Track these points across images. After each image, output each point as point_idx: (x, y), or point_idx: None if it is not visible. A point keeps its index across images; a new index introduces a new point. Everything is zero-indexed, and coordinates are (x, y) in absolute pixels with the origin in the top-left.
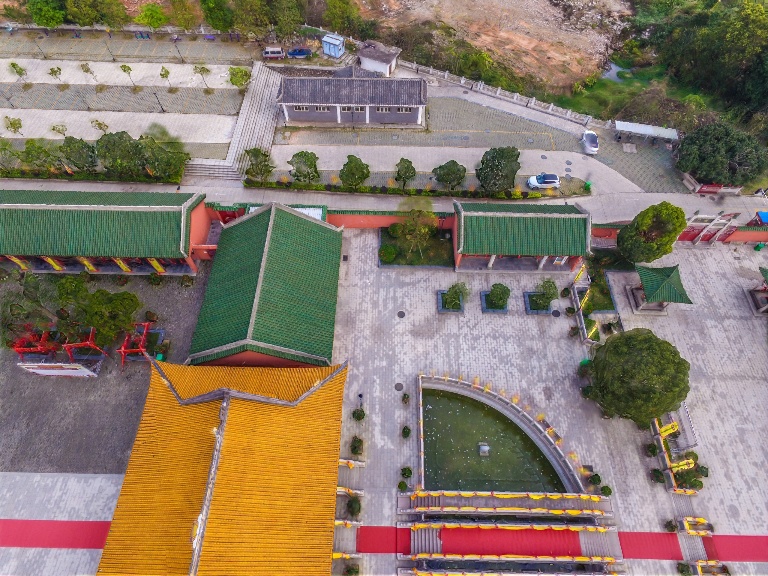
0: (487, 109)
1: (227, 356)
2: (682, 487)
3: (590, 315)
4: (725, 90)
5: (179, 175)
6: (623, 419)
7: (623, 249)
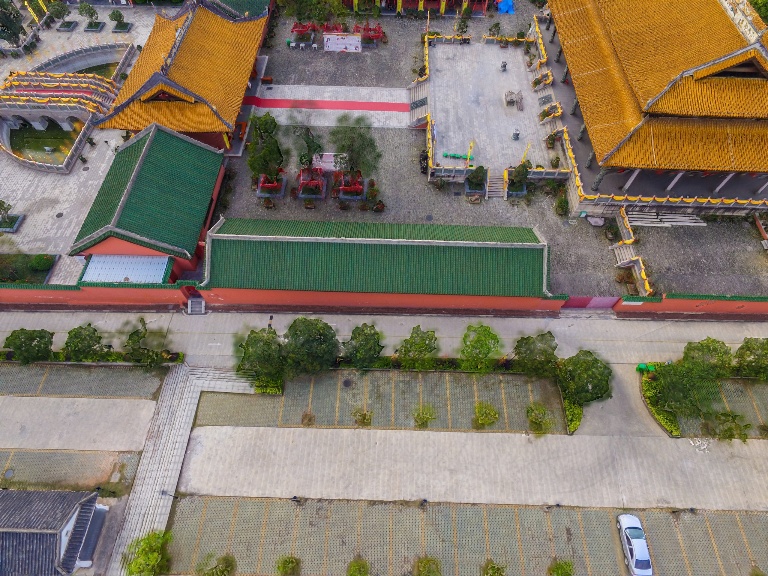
0: None
1: None
2: None
3: None
4: None
5: None
6: None
7: None
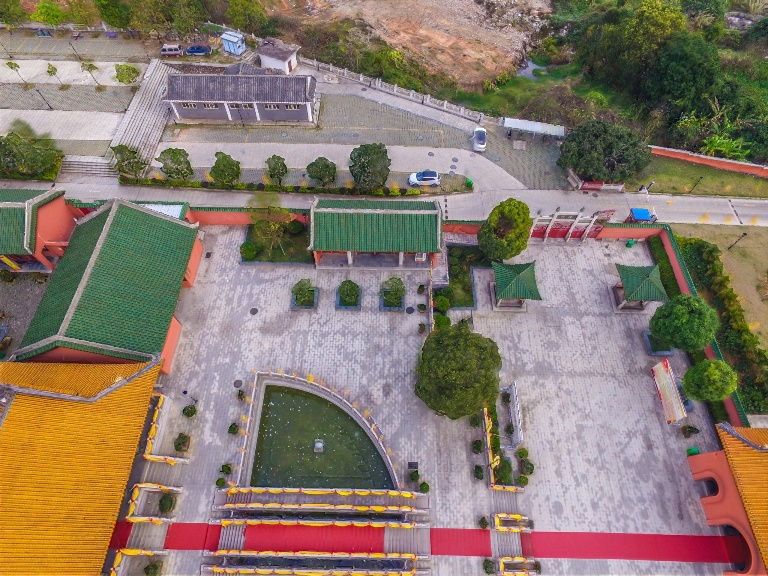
0: (382, 106)
1: (44, 352)
2: (501, 483)
3: (449, 312)
4: (632, 87)
5: (54, 172)
6: None
7: (481, 246)
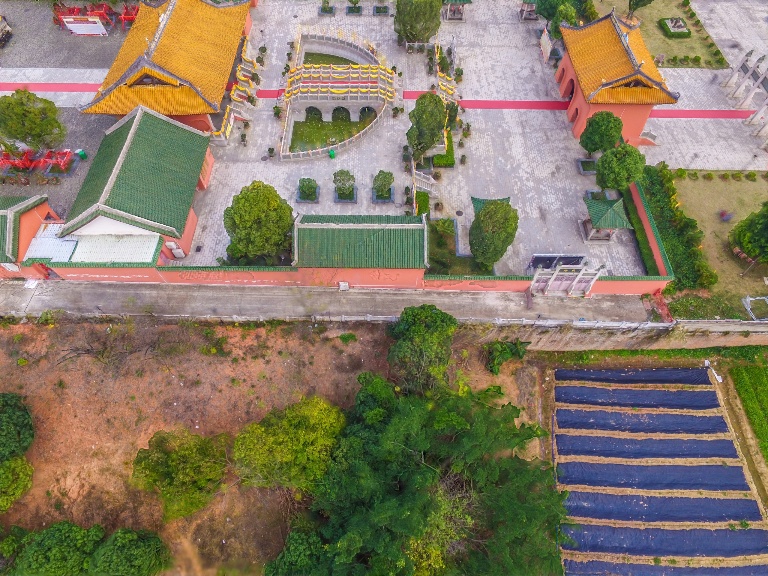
0: None
1: None
2: (443, 73)
3: None
4: None
5: None
6: (420, 54)
7: None
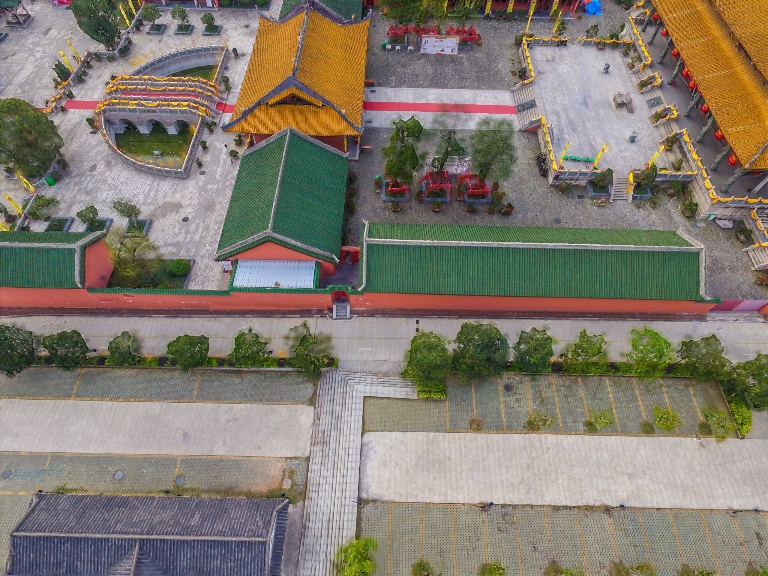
0: None
1: None
2: None
3: None
4: None
5: None
6: None
7: None
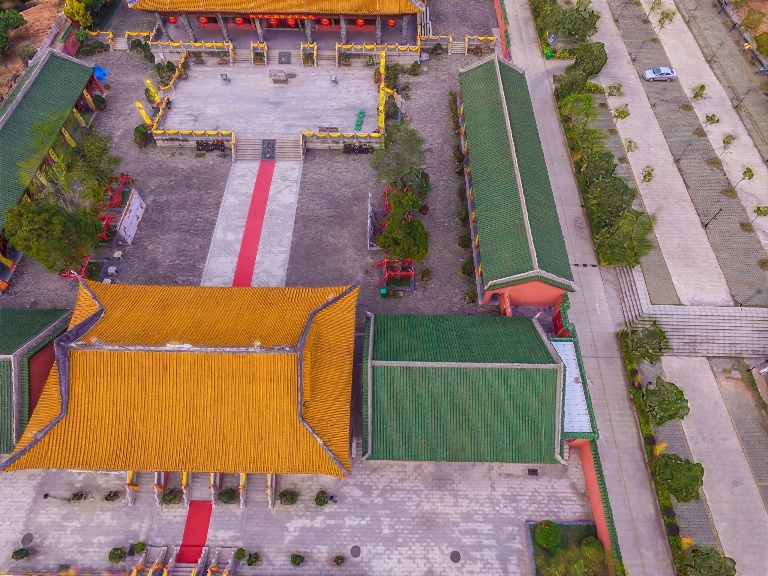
0: None
1: None
2: None
3: None
4: None
5: (611, 262)
6: None
7: None
